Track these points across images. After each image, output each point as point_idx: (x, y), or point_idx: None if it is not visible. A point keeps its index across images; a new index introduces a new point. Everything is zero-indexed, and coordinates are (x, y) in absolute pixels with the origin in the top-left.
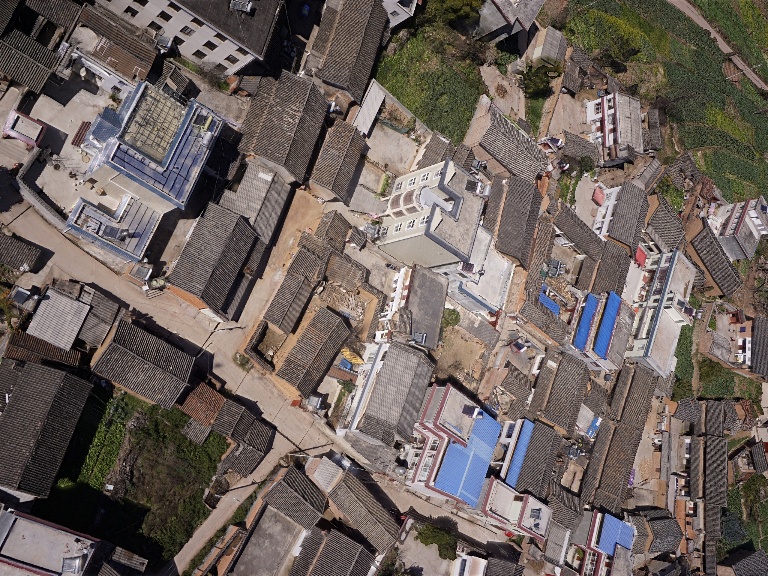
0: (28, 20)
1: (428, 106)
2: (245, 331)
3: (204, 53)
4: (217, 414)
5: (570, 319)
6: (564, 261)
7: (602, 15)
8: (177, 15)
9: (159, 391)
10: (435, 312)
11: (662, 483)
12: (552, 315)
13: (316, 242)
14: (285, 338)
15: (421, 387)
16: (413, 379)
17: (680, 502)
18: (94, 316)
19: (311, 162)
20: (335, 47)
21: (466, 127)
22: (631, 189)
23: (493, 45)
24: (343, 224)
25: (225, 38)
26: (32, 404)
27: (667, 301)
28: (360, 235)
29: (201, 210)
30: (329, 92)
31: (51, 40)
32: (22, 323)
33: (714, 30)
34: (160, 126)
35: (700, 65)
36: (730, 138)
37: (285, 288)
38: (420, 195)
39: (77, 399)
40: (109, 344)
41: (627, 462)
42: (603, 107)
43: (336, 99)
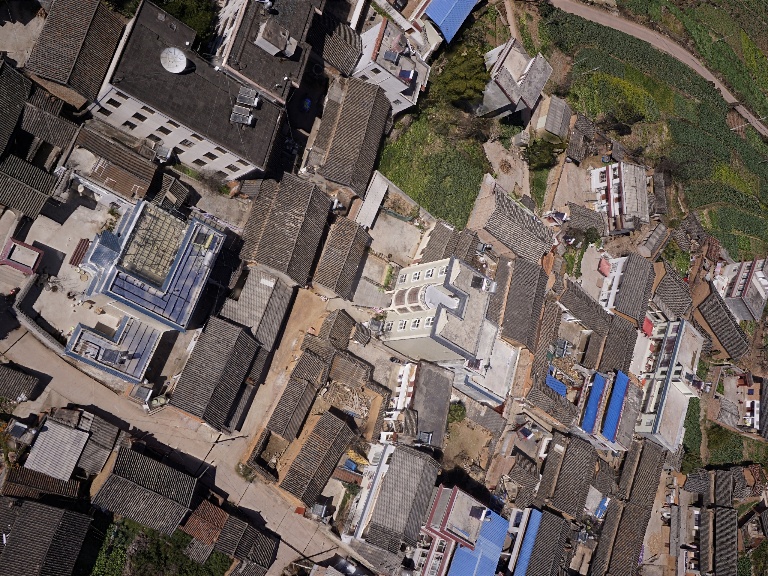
0: (24, 141)
1: (432, 190)
2: (248, 440)
3: (204, 162)
4: (220, 532)
5: (577, 397)
6: (570, 336)
7: (606, 77)
8: (176, 130)
9: (160, 518)
10: (441, 408)
11: (671, 558)
12: (559, 398)
13: (319, 344)
14: (288, 443)
15: (427, 489)
16: (419, 483)
17: (690, 575)
18: (93, 443)
19: (314, 261)
20: (337, 143)
21: (470, 208)
22: (637, 260)
23: (497, 121)
24: (347, 322)
25: (226, 151)
26: (30, 546)
27: (675, 374)
28: (364, 333)
29: (202, 319)
30: (331, 187)
31: (48, 157)
32: (20, 457)
33: (718, 80)
34: (160, 244)
35: (704, 119)
36: (735, 192)
37: (288, 394)
38: (425, 294)
39: (76, 535)
40: (109, 476)
41: (636, 544)
42: (608, 176)
43: (339, 194)
